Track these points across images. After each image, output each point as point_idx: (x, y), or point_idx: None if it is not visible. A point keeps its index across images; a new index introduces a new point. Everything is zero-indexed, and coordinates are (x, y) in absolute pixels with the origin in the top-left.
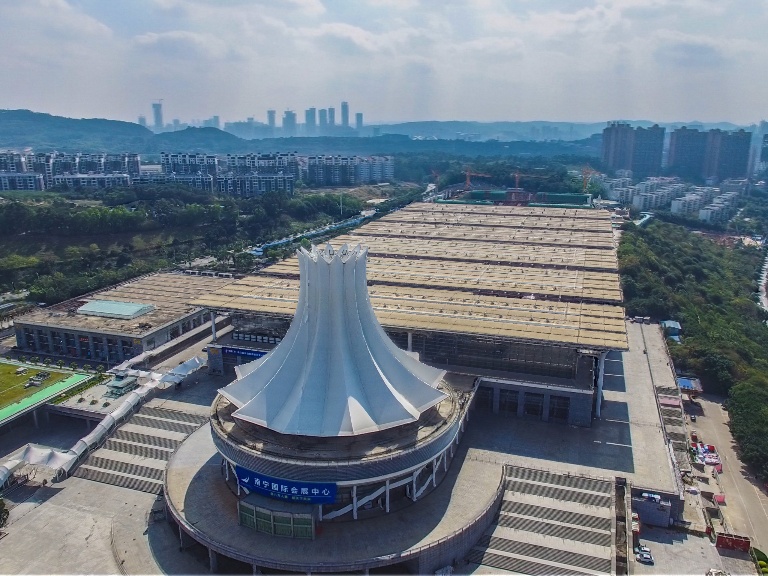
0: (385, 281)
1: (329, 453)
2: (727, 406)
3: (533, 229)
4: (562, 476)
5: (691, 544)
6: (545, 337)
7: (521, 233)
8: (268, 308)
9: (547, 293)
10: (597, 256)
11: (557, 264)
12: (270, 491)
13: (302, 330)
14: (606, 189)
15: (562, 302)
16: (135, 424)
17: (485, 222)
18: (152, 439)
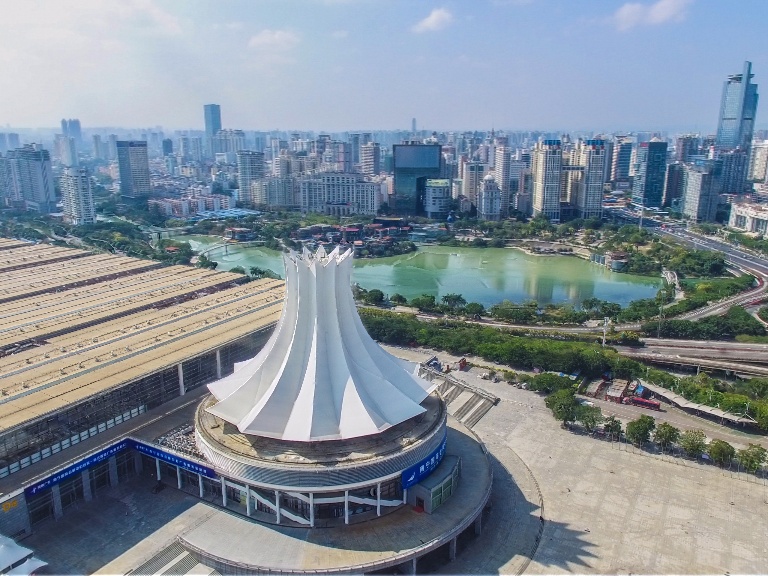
0: (51, 332)
1: (433, 410)
2: None
3: None
4: None
5: (457, 375)
6: None
7: None
8: (71, 396)
9: (203, 287)
10: (113, 260)
11: (118, 272)
12: None
13: None
14: None
15: (233, 288)
16: None
17: None
18: None
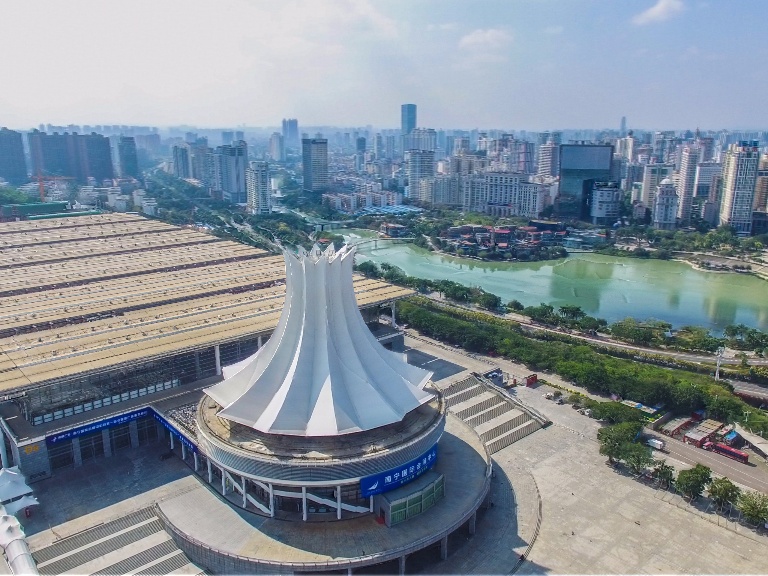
0: (131, 306)
1: (422, 422)
2: (417, 323)
3: (110, 237)
4: (450, 388)
5: (520, 391)
6: (368, 301)
7: (113, 242)
8: (100, 362)
9: (284, 277)
10: (231, 247)
11: (225, 258)
12: (401, 480)
13: (328, 334)
14: (81, 194)
15: None
16: (59, 574)
17: (42, 239)
18: (120, 567)
